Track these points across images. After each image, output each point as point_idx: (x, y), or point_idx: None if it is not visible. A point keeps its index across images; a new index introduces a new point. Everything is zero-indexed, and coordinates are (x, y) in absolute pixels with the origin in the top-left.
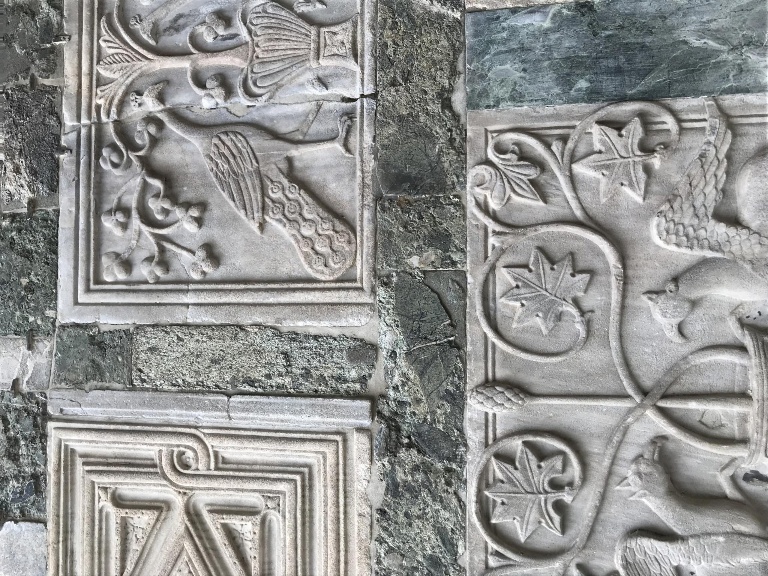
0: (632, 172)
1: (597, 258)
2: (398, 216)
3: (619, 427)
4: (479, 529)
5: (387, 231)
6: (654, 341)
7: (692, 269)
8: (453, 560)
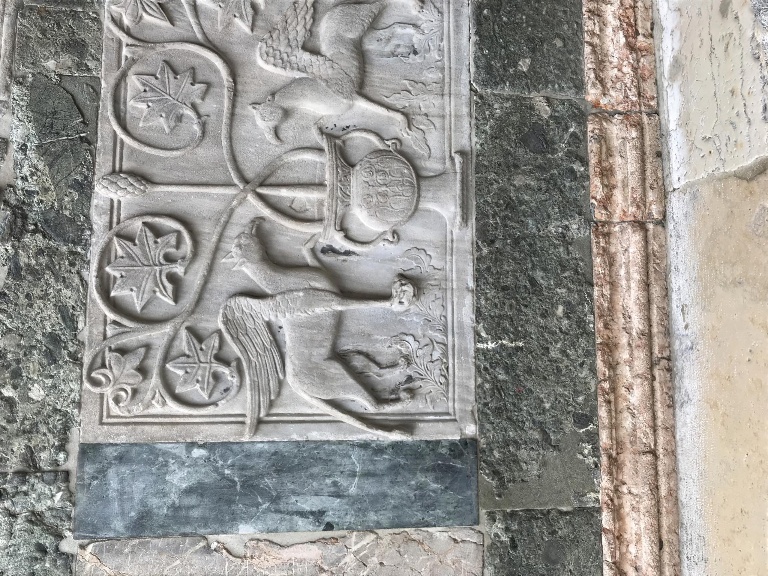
0: (243, 7)
1: (214, 74)
2: (37, 24)
3: (226, 210)
4: (99, 304)
5: (26, 37)
6: (257, 143)
7: (286, 86)
8: (72, 336)
